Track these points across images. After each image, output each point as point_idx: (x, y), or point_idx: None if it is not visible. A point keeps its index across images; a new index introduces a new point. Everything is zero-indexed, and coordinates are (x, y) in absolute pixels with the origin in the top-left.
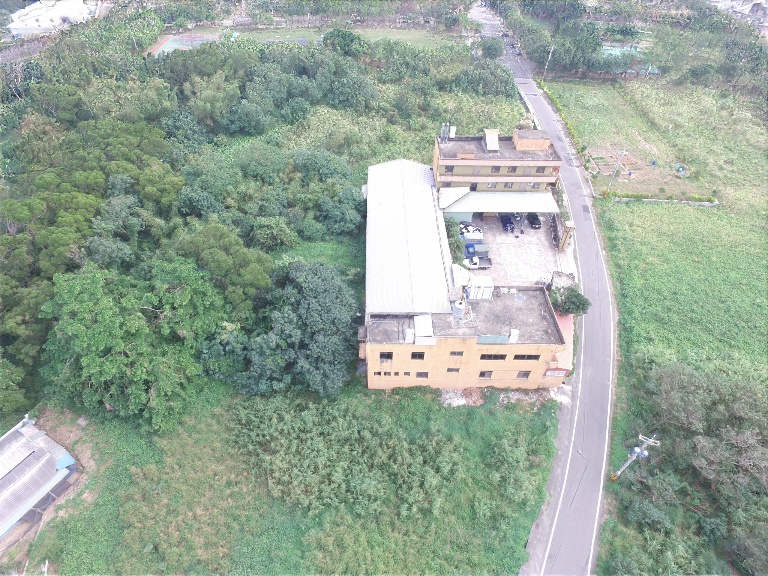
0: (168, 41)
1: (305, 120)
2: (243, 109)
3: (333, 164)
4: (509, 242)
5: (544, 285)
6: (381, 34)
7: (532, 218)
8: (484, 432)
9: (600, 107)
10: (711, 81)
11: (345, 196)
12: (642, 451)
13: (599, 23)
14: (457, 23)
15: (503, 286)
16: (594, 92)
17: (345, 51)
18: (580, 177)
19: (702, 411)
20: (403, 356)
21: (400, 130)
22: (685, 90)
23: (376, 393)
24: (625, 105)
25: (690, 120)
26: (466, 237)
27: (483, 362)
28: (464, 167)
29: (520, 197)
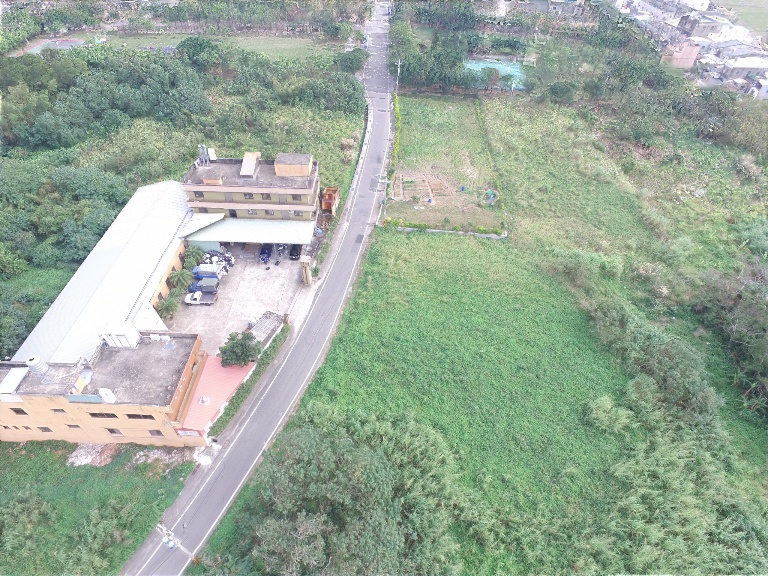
0: (38, 45)
1: (114, 134)
2: (40, 122)
3: (95, 184)
4: (256, 274)
5: (251, 326)
6: (262, 42)
7: (292, 248)
8: (90, 498)
9: (445, 125)
10: (580, 99)
11: (89, 220)
12: (169, 541)
13: (501, 34)
14: (340, 32)
15: (154, 332)
16: (450, 109)
17: (193, 61)
18: (374, 203)
19: (293, 489)
20: (2, 411)
21: (214, 146)
22: (545, 109)
23: (3, 447)
24: (474, 124)
25: (532, 142)
26: (199, 269)
27: (97, 420)
28: (213, 193)
29: (278, 226)
